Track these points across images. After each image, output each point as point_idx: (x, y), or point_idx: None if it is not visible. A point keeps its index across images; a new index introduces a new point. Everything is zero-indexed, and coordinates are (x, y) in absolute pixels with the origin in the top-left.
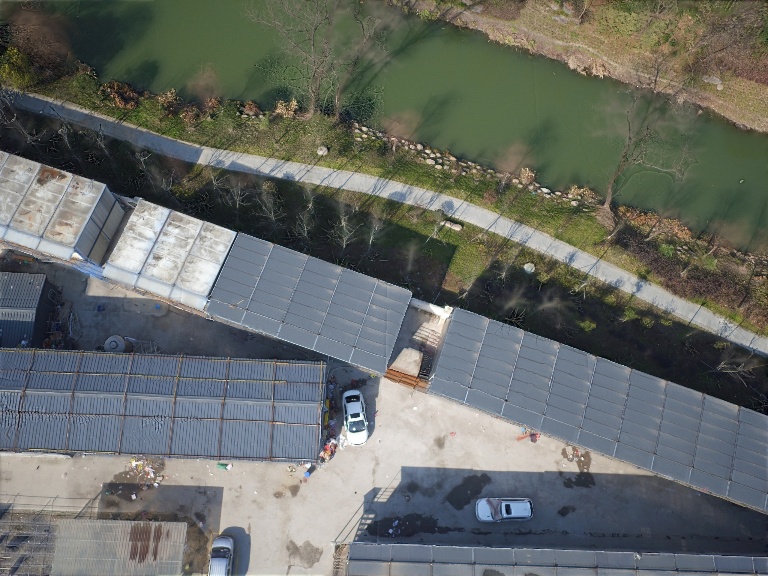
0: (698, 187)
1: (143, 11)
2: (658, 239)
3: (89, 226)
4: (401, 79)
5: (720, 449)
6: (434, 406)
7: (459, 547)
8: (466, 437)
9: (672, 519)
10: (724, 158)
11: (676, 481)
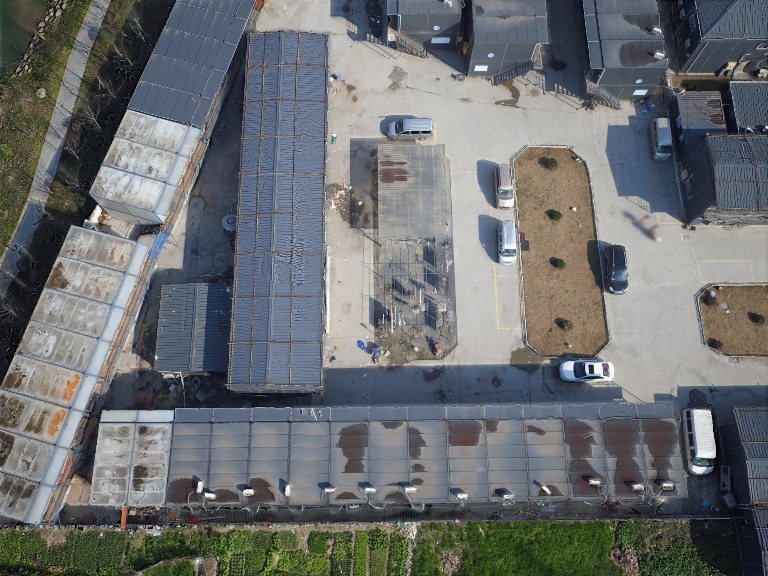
0: None
1: None
2: None
3: None
4: None
5: None
6: None
7: None
8: None
9: None
10: None
11: None
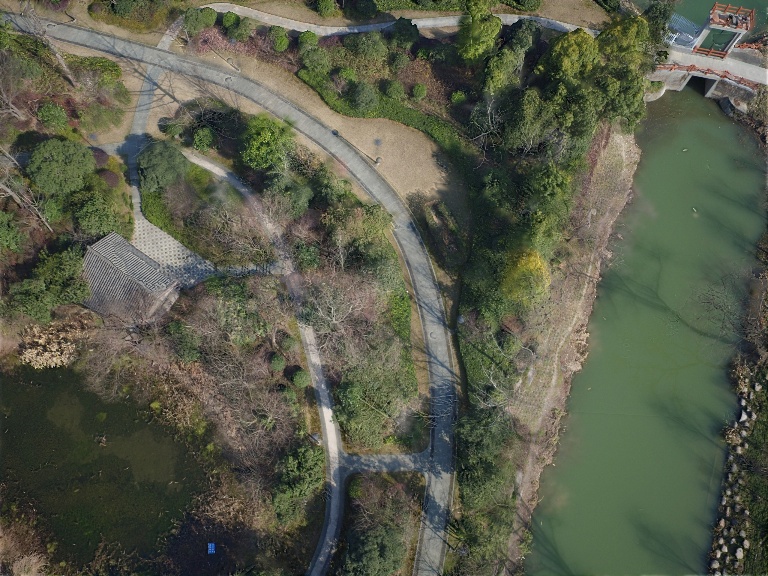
0: (708, 254)
1: None
2: None
3: None
4: None
5: None
6: None
7: None
8: None
9: None
10: (670, 222)
11: None
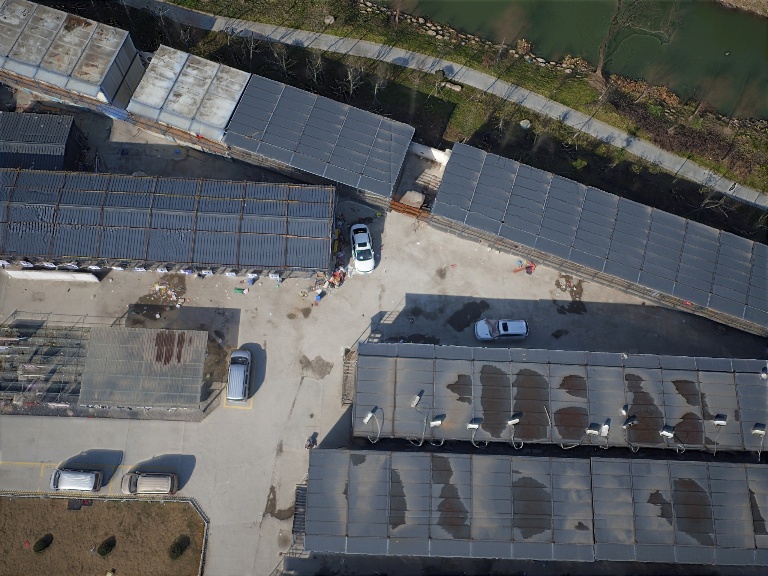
0: (686, 59)
1: None
2: (647, 103)
3: (113, 69)
4: None
5: (702, 266)
6: (436, 241)
7: (459, 346)
8: (466, 269)
9: (658, 342)
10: (711, 33)
11: (661, 301)
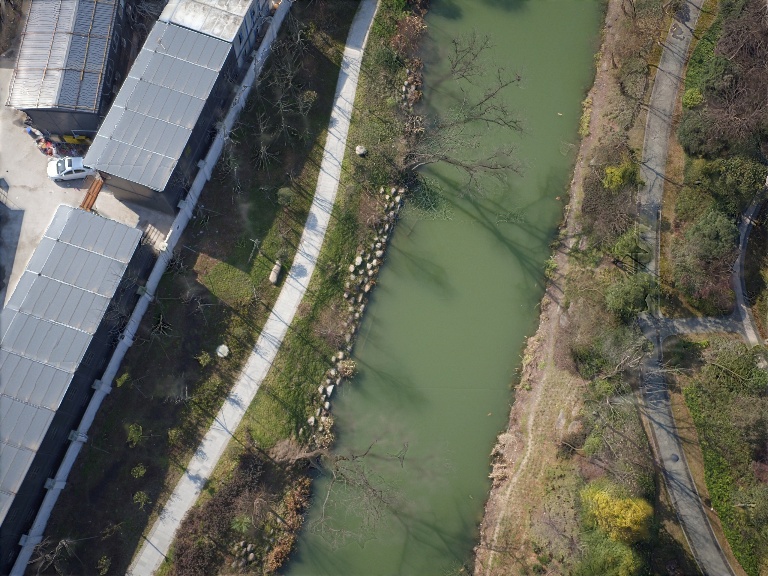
0: None
1: (515, 2)
2: (264, 521)
3: None
4: (463, 237)
5: None
6: None
7: None
8: None
9: None
10: None
11: None
